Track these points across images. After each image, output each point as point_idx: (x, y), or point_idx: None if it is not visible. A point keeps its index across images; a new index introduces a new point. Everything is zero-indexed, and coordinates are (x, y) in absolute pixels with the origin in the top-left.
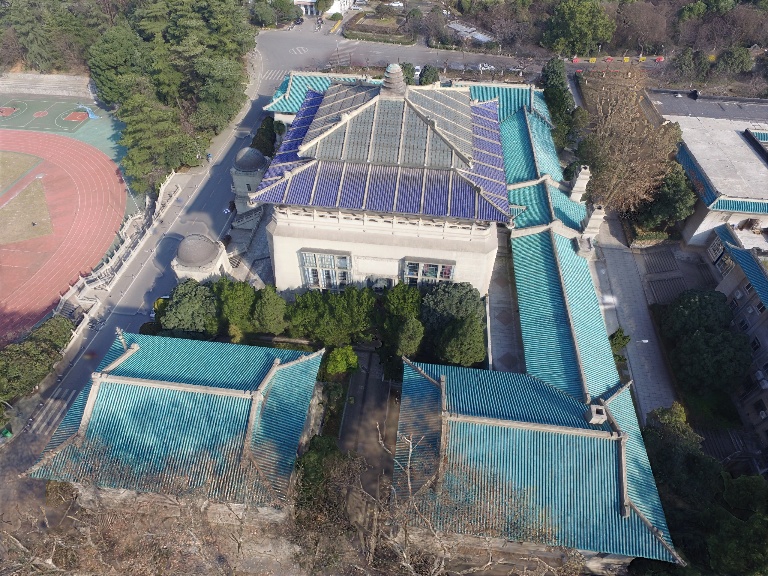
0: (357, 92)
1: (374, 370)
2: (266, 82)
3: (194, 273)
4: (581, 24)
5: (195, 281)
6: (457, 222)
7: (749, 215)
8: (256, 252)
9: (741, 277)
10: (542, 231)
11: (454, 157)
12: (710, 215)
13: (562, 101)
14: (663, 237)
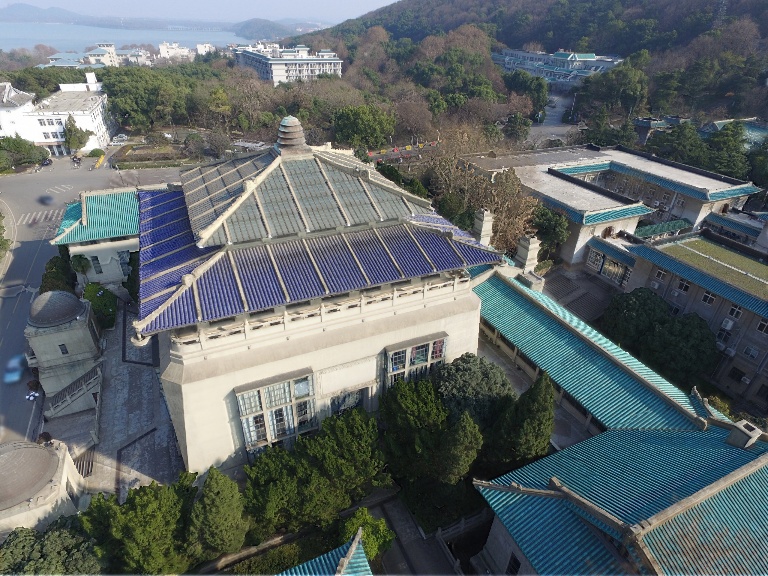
0: (236, 165)
1: (402, 529)
2: (25, 227)
3: (17, 517)
4: (368, 121)
5: (28, 531)
6: (429, 283)
7: (606, 224)
8: (115, 437)
9: (648, 269)
10: (488, 277)
11: (408, 204)
12: (582, 232)
13: (399, 175)
14: (550, 264)
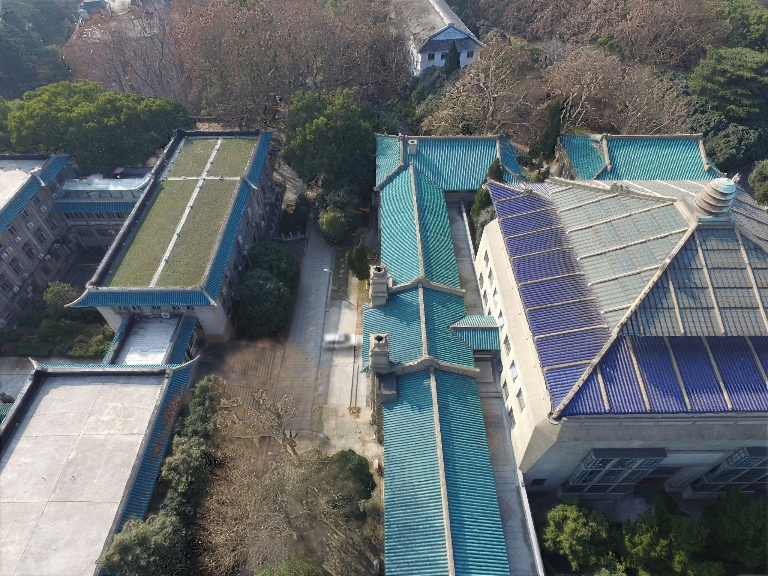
0: None
1: None
2: None
3: None
4: None
5: None
6: None
7: None
8: None
9: None
10: None
11: None
12: None
13: None
14: None
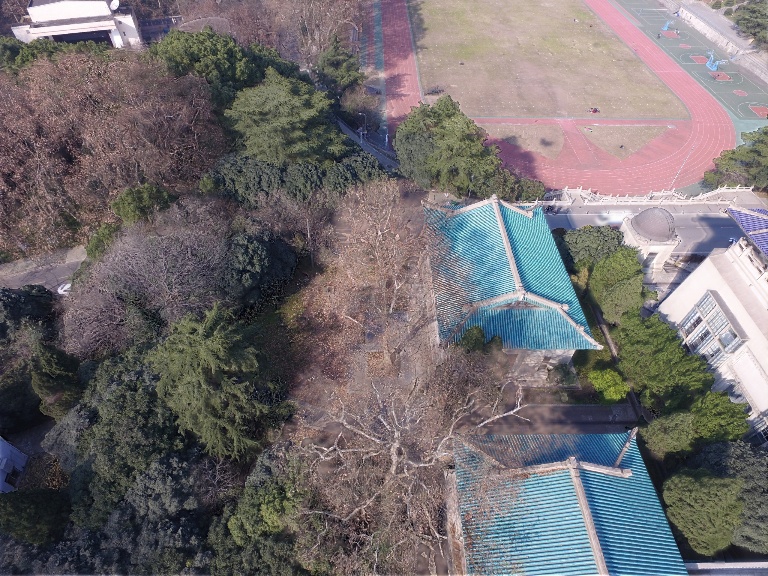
0: None
1: (618, 429)
2: None
3: (630, 235)
4: None
5: (621, 237)
6: None
7: None
8: None
9: None
10: None
11: None
12: None
13: None
14: None
